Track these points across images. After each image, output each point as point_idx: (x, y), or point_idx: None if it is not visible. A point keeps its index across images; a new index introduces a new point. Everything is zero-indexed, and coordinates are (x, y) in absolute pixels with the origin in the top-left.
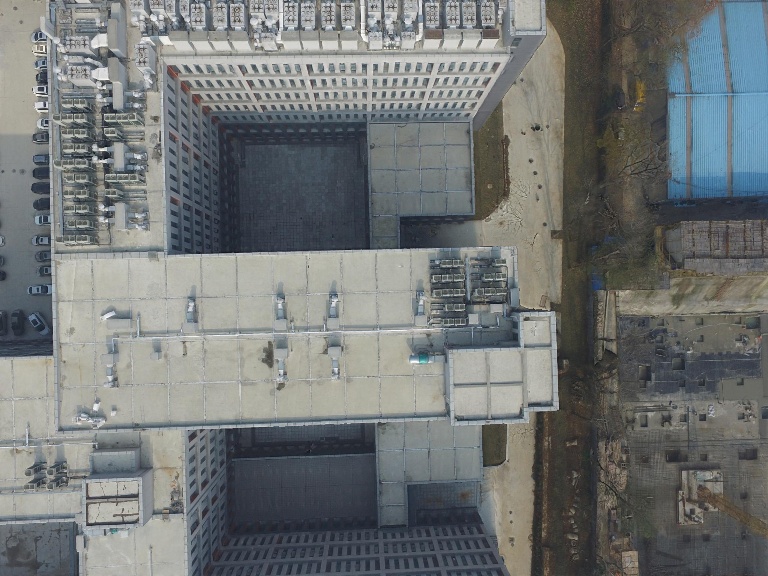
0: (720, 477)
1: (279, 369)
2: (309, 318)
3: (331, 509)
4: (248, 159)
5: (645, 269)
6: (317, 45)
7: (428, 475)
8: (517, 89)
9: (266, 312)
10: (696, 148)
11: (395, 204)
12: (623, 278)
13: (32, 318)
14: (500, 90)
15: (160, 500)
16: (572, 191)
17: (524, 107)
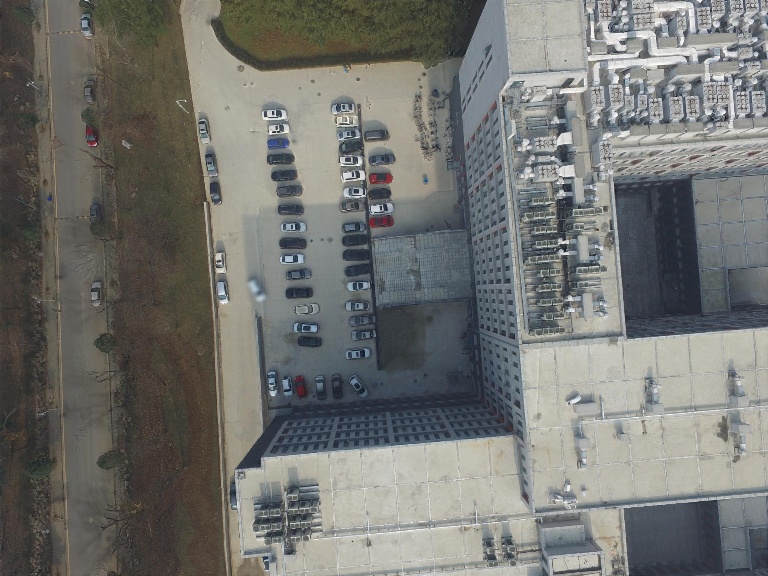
0: None
1: (742, 444)
2: (759, 392)
3: (657, 553)
4: None
5: None
6: (760, 129)
7: (767, 519)
8: None
9: (719, 388)
10: None
11: (721, 257)
12: None
13: (354, 382)
14: None
15: None
16: None
17: None
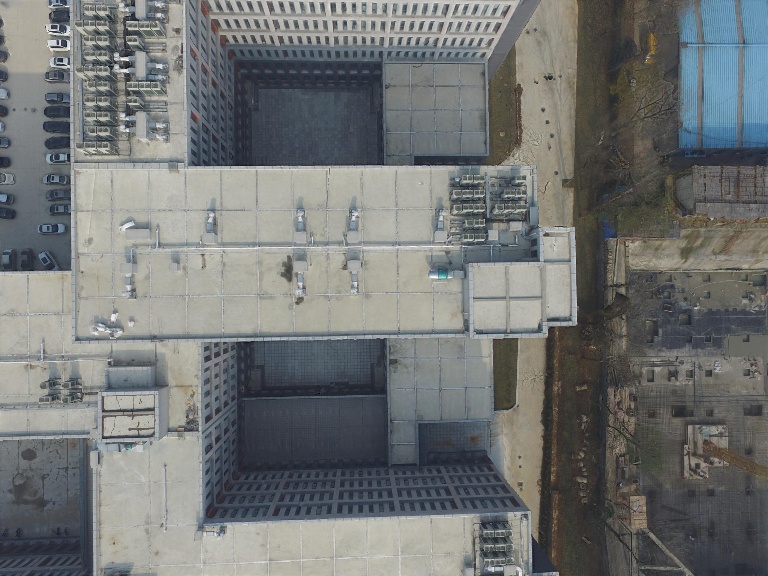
0: (725, 432)
1: (298, 282)
2: (328, 233)
3: (341, 451)
4: (261, 103)
5: (658, 210)
6: None
7: (439, 414)
8: (530, 38)
9: (286, 226)
10: (707, 98)
11: (409, 144)
12: (634, 226)
13: (42, 256)
14: (517, 25)
15: (175, 418)
16: (584, 140)
17: (537, 56)
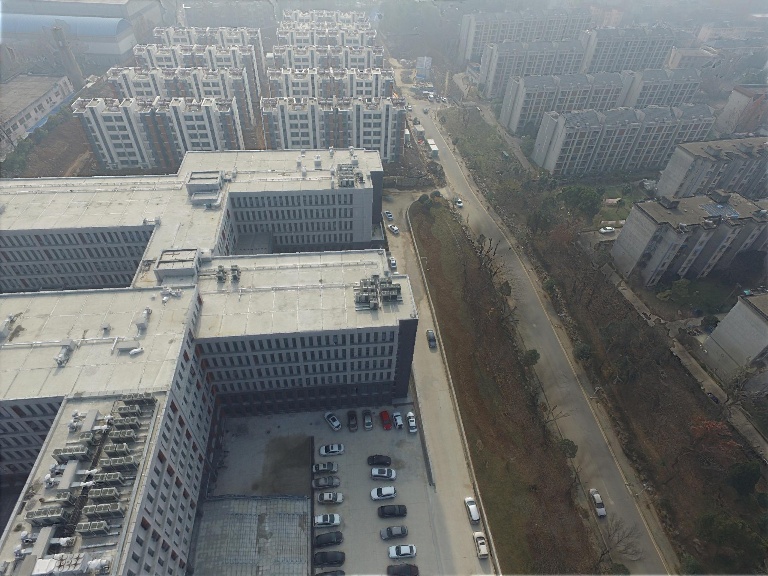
0: None
1: (7, 321)
2: None
3: None
4: None
5: None
6: None
7: None
8: None
9: (1, 360)
10: None
11: None
12: None
13: (336, 423)
14: None
15: None
16: None
17: None
